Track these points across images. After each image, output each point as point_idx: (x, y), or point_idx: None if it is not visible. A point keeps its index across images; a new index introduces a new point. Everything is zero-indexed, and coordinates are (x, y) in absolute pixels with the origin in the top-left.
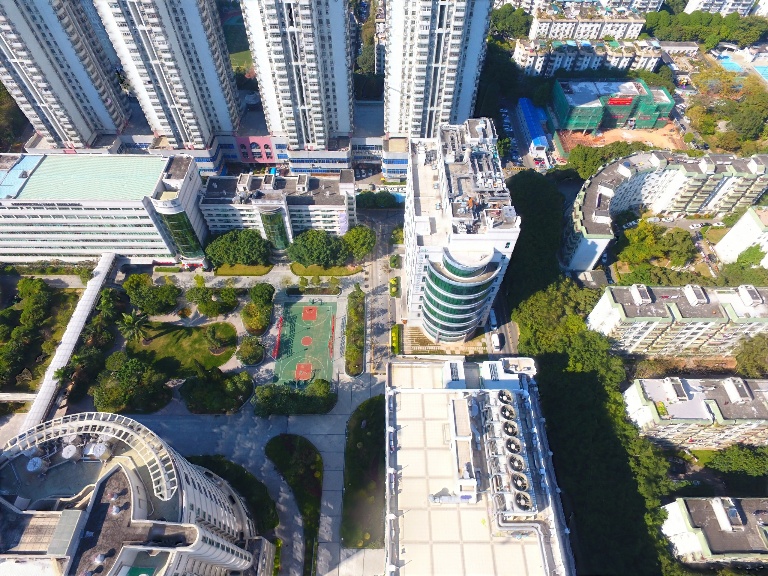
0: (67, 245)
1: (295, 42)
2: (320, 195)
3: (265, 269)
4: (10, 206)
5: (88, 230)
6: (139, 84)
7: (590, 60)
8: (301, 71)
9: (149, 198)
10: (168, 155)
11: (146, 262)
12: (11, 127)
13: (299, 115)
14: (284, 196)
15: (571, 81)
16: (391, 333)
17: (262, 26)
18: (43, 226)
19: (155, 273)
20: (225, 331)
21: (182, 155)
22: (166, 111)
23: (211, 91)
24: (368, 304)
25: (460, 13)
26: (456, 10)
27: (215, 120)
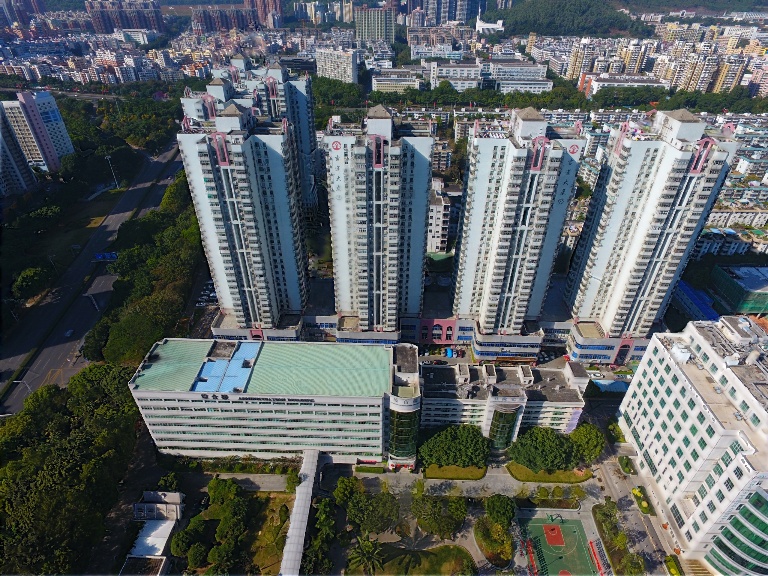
0: (271, 440)
1: (521, 238)
2: (548, 389)
3: (480, 471)
4: (235, 400)
5: (304, 426)
6: (342, 270)
7: (737, 246)
8: (519, 263)
9: (388, 394)
10: (355, 337)
11: (350, 461)
12: (183, 303)
13: (502, 302)
14: (524, 393)
15: (731, 266)
16: (668, 568)
17: (482, 223)
18: (257, 420)
19: (355, 473)
20: (460, 559)
21: (405, 344)
22: (369, 296)
23: (410, 277)
24: (619, 523)
25: (696, 216)
26: (692, 214)
27: (404, 303)
